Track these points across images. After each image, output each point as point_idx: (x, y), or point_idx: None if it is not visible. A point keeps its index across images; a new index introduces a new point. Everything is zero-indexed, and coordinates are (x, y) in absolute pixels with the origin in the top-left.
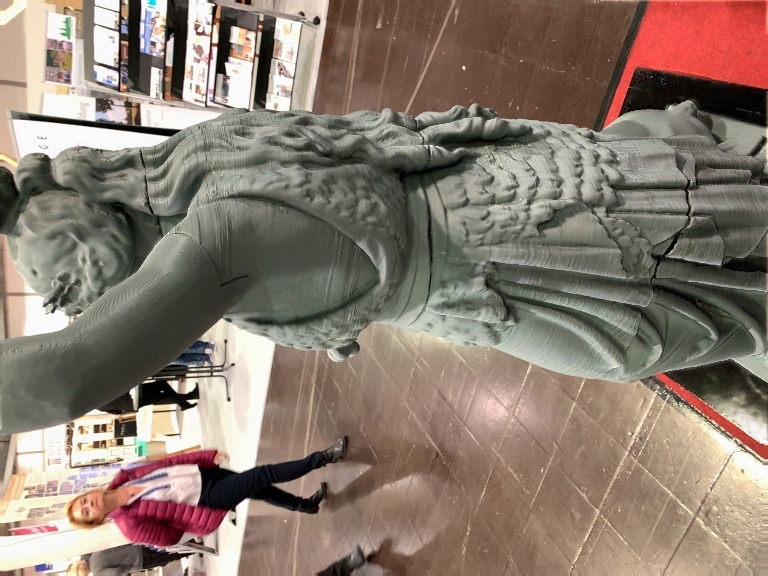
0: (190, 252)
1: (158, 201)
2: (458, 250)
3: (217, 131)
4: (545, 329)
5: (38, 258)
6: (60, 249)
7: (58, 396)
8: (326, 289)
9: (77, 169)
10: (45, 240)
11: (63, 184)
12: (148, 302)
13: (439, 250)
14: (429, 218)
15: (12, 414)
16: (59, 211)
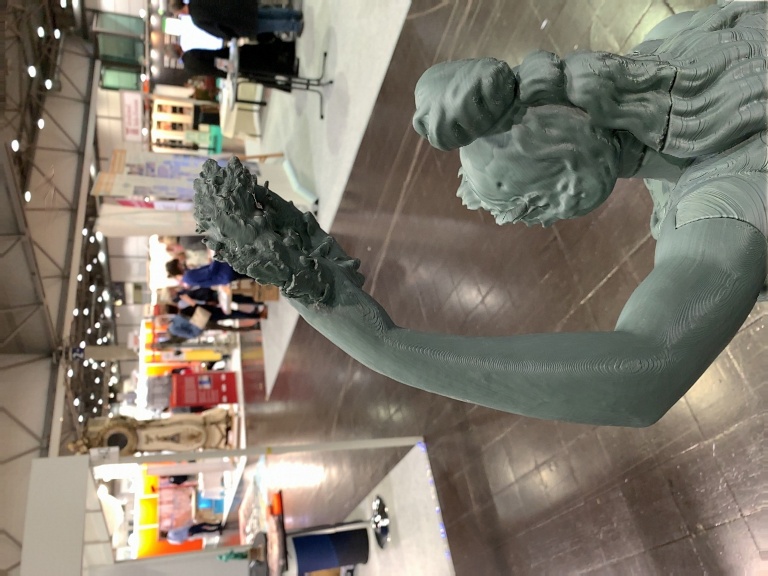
0: (758, 251)
1: (680, 143)
2: None
3: None
4: None
5: (514, 175)
6: (544, 172)
7: (648, 414)
8: None
9: (601, 89)
10: (532, 160)
11: (576, 102)
12: (723, 315)
13: None
14: None
15: (600, 420)
16: (561, 133)
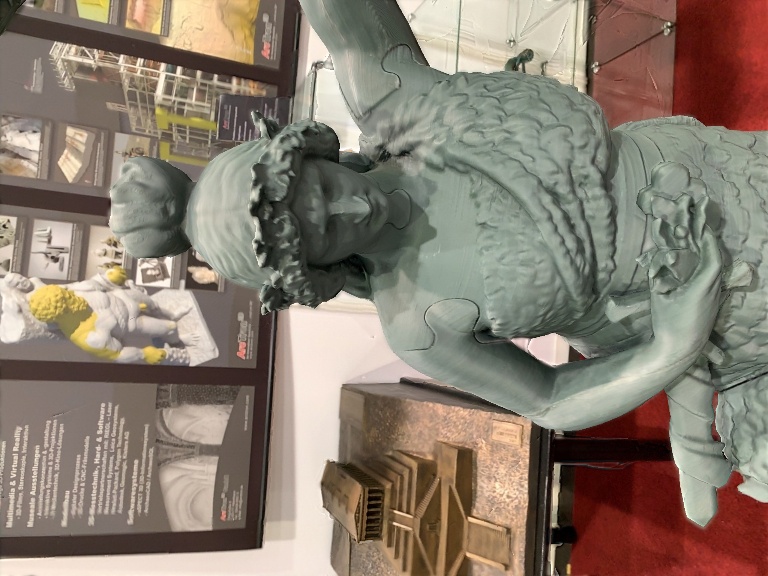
0: None
1: None
2: None
3: None
4: None
5: None
6: None
7: None
8: None
9: None
10: None
11: None
12: None
13: None
14: None
15: None
16: None
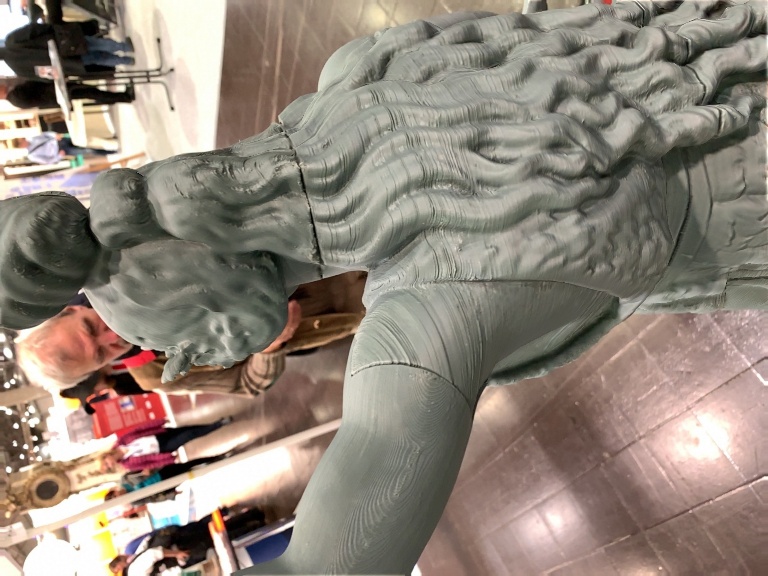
0: (443, 403)
1: (337, 255)
2: (710, 254)
3: (438, 144)
4: (742, 293)
5: (148, 329)
6: (183, 320)
7: None
8: (552, 337)
9: (201, 214)
10: (158, 311)
11: (178, 235)
12: (409, 510)
13: (684, 253)
14: (686, 214)
15: None
16: (177, 274)
